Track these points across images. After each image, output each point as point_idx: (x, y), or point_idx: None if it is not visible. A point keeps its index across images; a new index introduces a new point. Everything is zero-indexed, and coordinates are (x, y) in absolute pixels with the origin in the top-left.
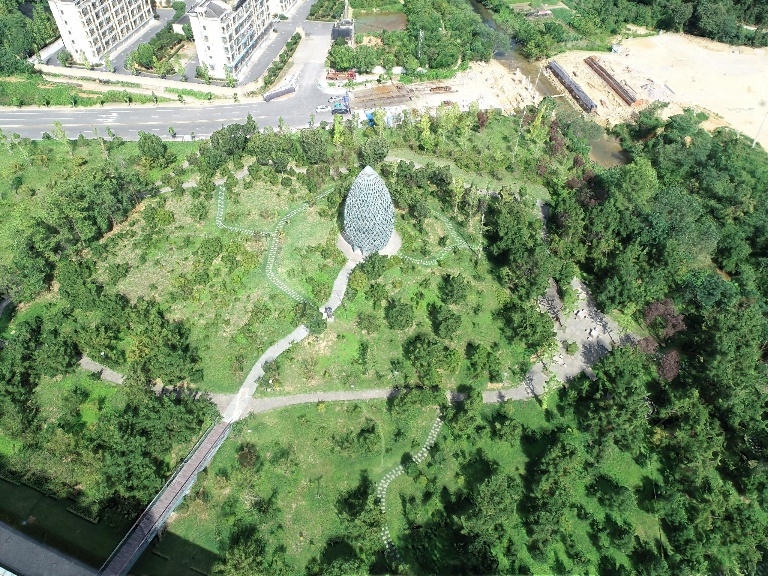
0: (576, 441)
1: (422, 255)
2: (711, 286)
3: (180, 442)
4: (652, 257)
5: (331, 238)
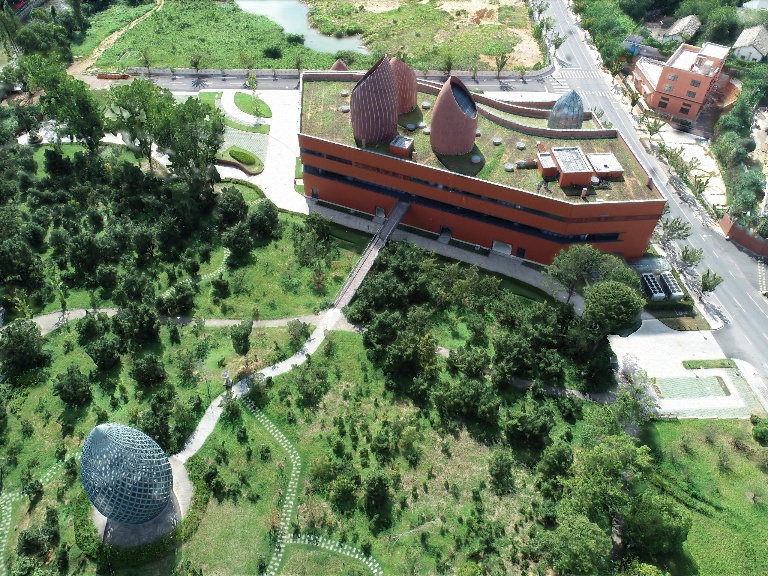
0: None
1: None
2: None
3: None
4: None
5: (198, 509)
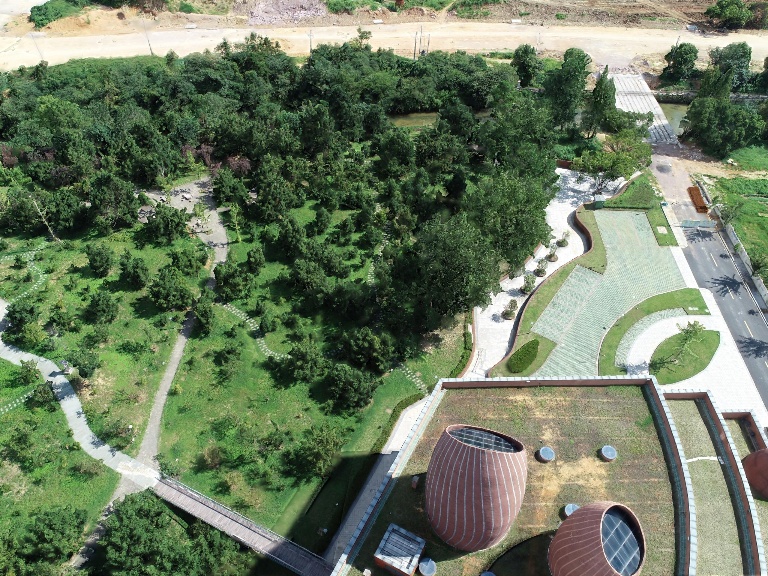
0: (273, 232)
1: (27, 283)
2: (183, 125)
3: (170, 523)
4: (138, 141)
5: None
